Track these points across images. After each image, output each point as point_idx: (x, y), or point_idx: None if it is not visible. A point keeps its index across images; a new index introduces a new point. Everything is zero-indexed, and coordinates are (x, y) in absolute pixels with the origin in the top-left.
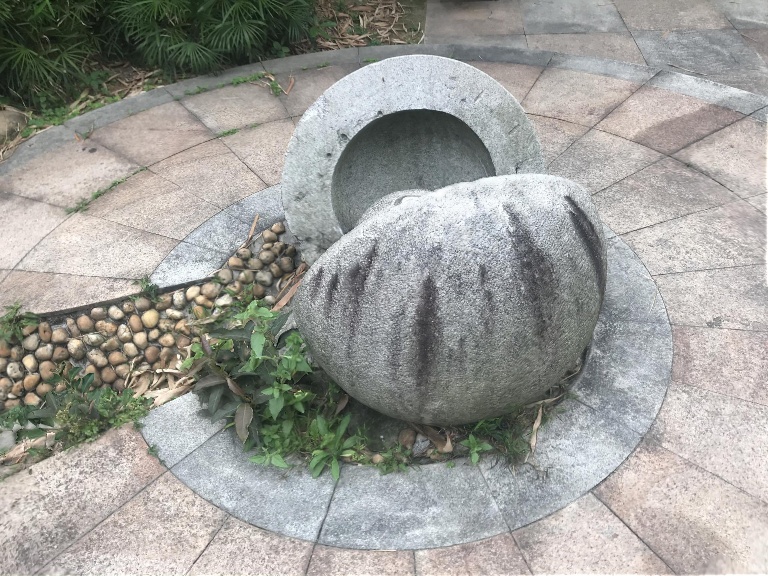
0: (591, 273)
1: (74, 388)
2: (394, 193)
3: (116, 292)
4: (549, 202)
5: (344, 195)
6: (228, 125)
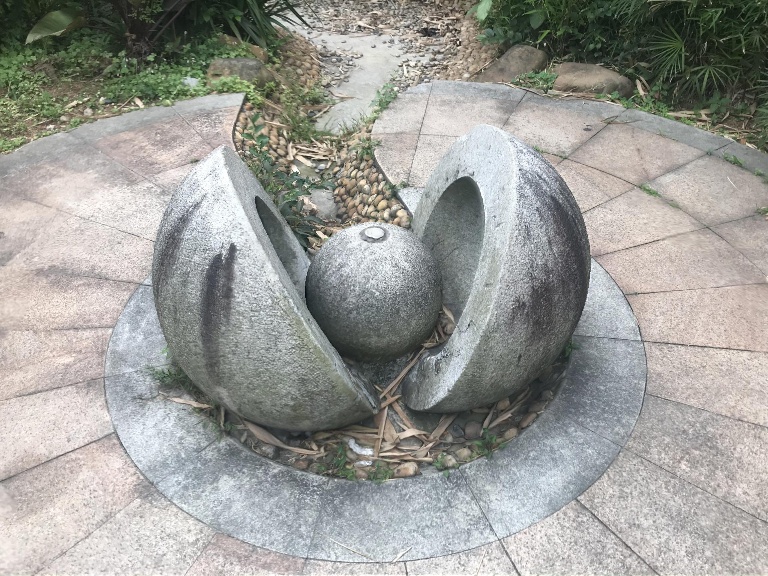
0: (196, 312)
1: (316, 187)
2: (403, 230)
3: (394, 176)
4: (219, 228)
5: (461, 233)
6: (666, 189)
